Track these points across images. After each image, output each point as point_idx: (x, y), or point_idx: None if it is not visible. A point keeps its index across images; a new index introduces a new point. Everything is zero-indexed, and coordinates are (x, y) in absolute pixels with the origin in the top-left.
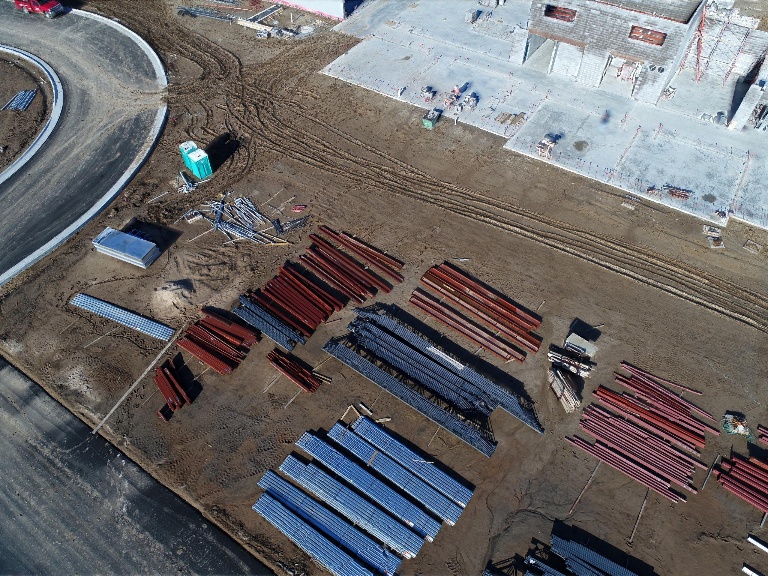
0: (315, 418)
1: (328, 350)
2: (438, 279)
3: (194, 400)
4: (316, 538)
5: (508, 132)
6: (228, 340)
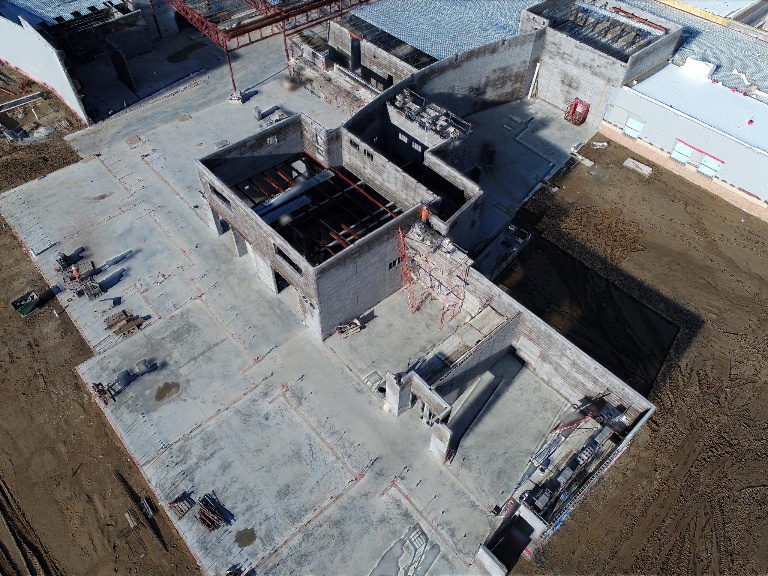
0: None
1: None
2: None
3: None
4: None
5: (101, 345)
6: None
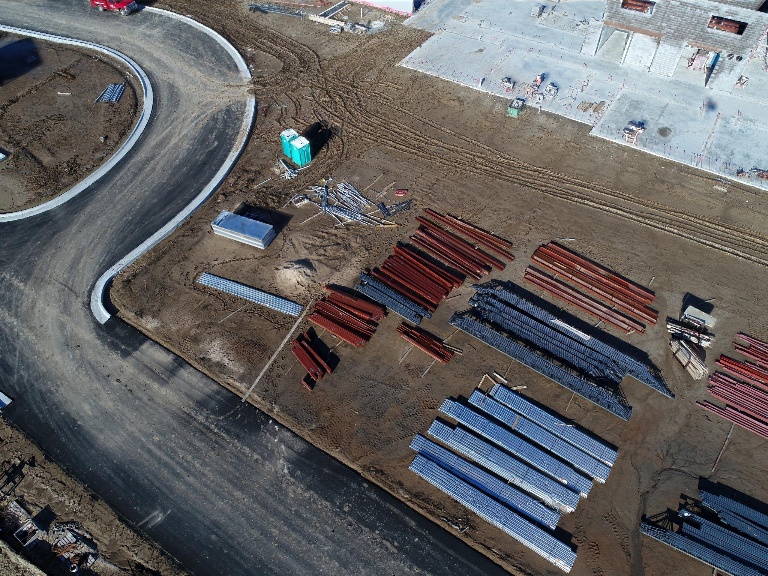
0: (453, 386)
1: (455, 323)
2: (548, 257)
3: (333, 370)
4: (477, 494)
5: (592, 120)
6: (357, 315)
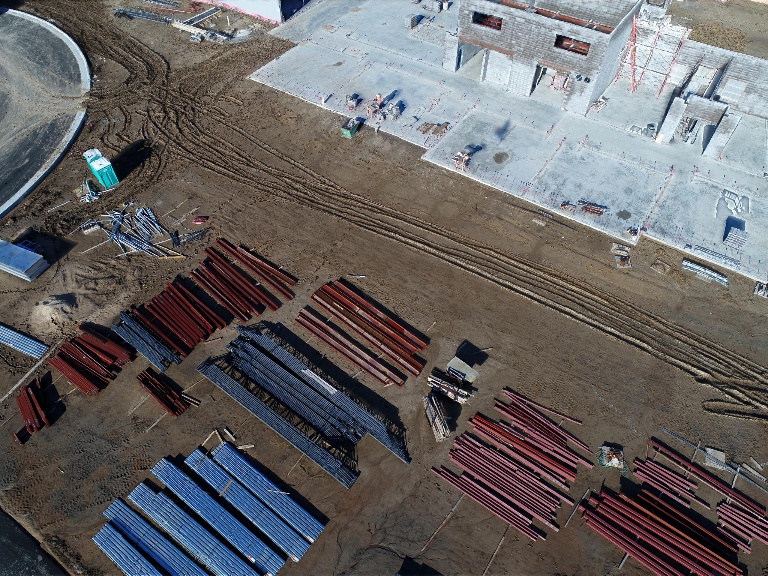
0: (176, 443)
1: (201, 371)
2: (329, 297)
3: (55, 422)
4: (149, 574)
5: (428, 142)
6: (101, 359)
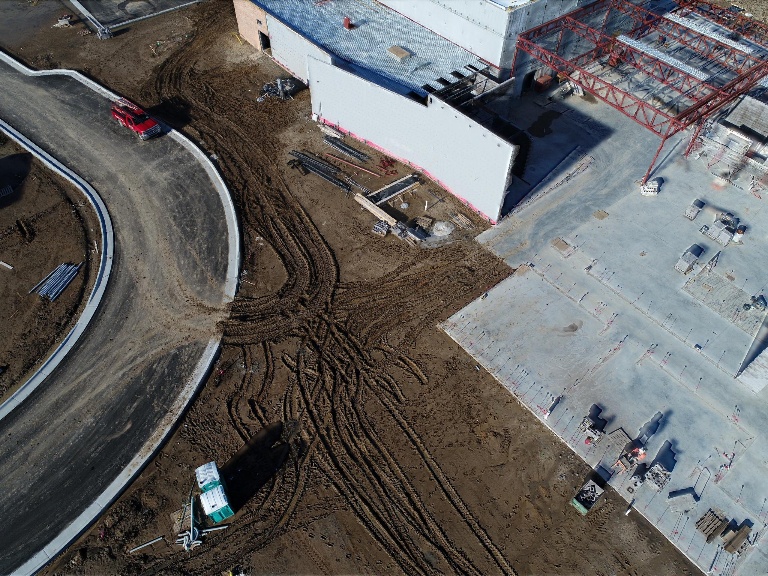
0: None
1: None
2: None
3: None
4: None
5: (717, 568)
6: None
